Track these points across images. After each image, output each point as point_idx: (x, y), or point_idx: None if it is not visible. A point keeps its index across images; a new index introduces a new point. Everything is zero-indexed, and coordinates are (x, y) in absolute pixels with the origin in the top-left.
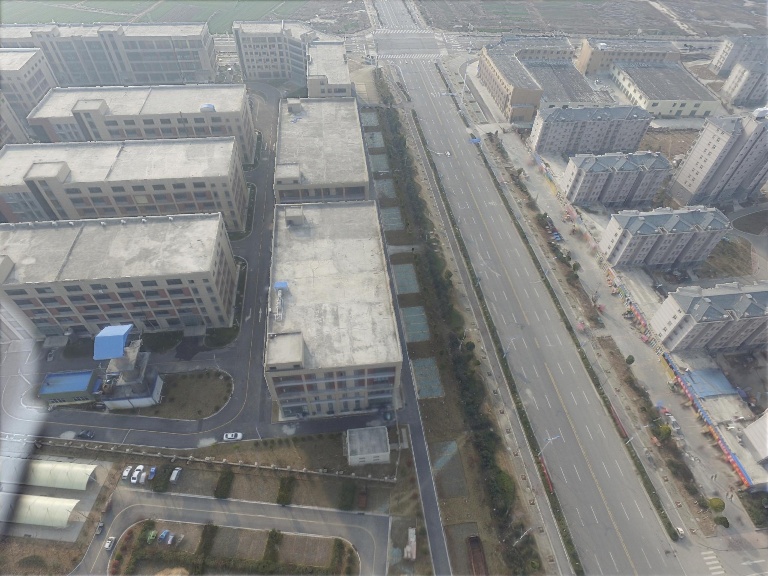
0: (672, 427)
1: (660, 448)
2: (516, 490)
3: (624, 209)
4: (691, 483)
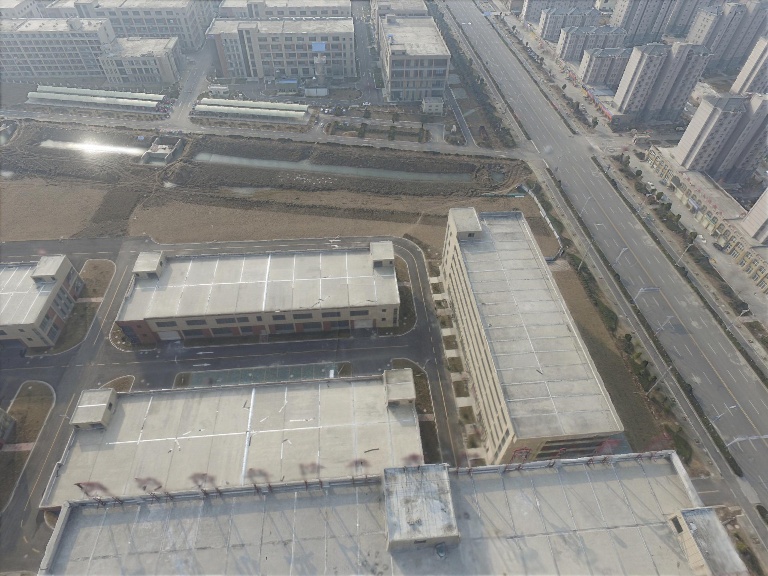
0: (581, 107)
1: (574, 113)
2: (502, 121)
3: None
4: None
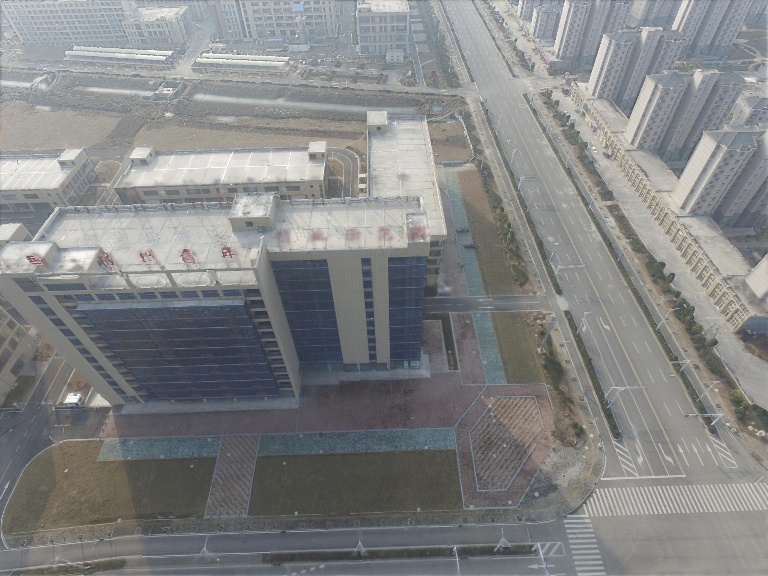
0: (527, 57)
1: (519, 61)
2: (454, 68)
3: None
4: None
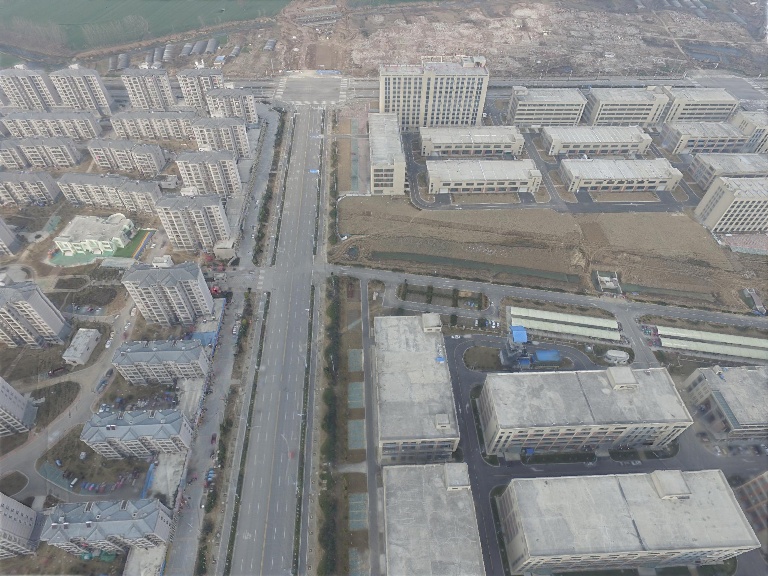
0: None
1: None
2: None
3: None
4: (247, 308)
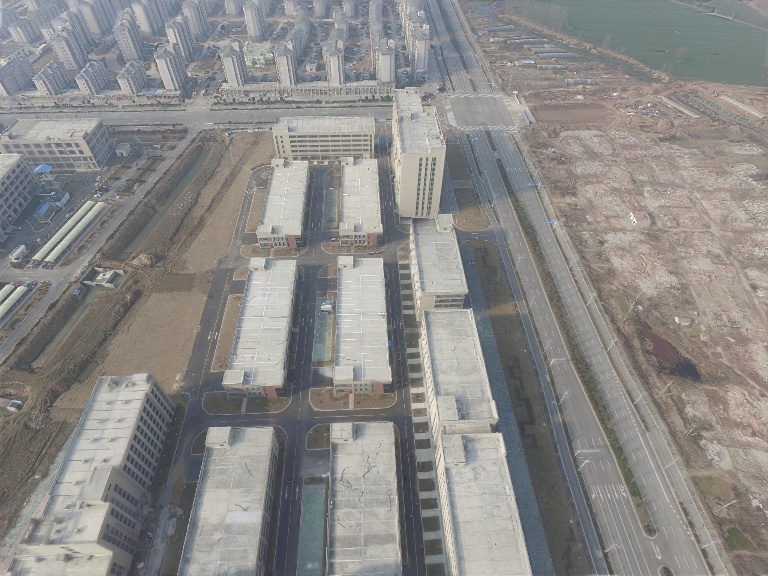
0: None
1: (163, 106)
2: None
3: (69, 88)
4: None
